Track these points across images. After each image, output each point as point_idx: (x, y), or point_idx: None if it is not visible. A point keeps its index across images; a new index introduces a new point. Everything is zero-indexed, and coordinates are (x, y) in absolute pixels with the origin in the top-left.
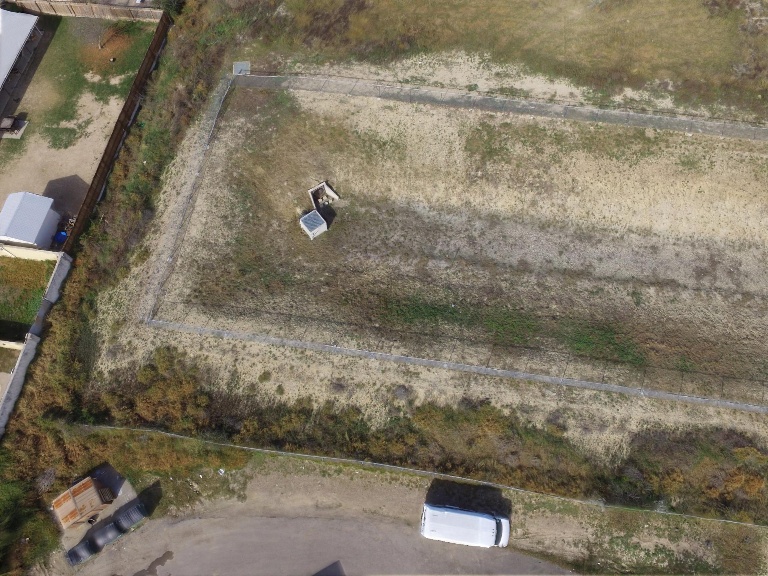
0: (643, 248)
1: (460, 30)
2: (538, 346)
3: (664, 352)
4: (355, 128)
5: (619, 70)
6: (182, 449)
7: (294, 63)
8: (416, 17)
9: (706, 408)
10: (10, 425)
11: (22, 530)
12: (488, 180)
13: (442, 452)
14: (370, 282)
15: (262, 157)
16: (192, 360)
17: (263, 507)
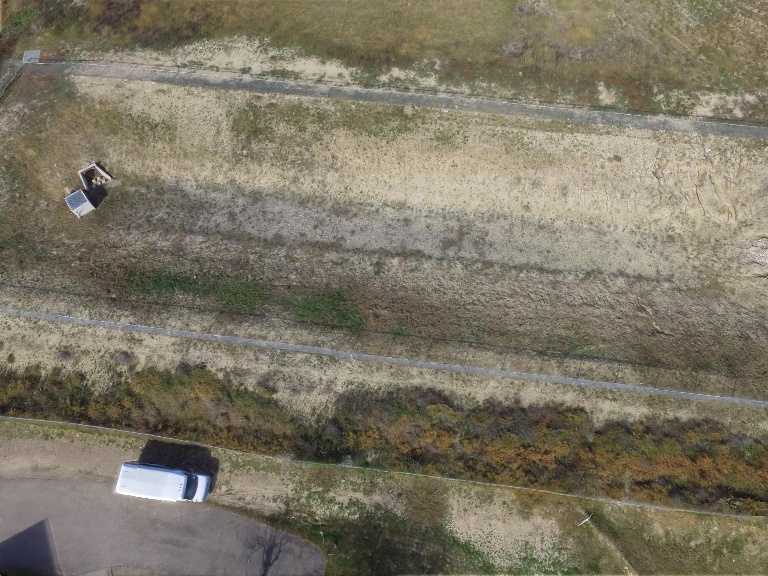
0: (396, 221)
1: (245, 16)
2: (263, 313)
3: (384, 317)
4: (129, 111)
5: (389, 51)
6: None
7: (80, 51)
8: (205, 5)
9: (410, 368)
10: None
11: None
12: (253, 158)
13: (157, 414)
14: (123, 257)
15: (35, 140)
16: None
17: None
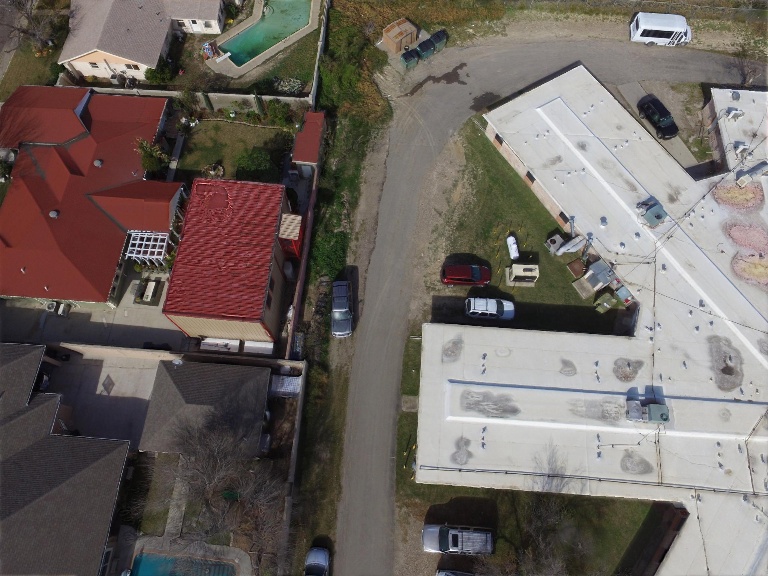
0: None
1: None
2: None
3: None
4: None
5: None
6: (460, 6)
7: None
8: None
9: None
10: (333, 1)
11: (361, 53)
12: None
13: None
14: None
15: None
16: None
17: (520, 39)
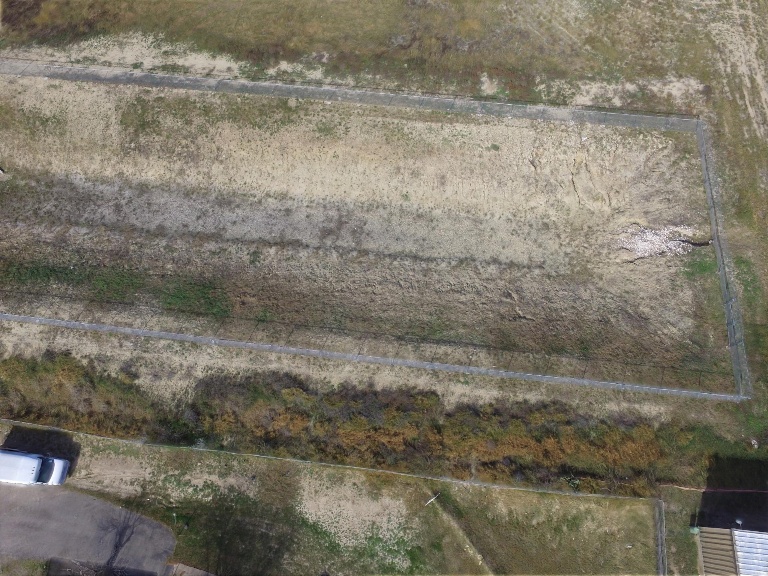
0: (277, 211)
1: (141, 12)
2: (133, 301)
3: (251, 304)
4: (21, 106)
5: (278, 45)
6: None
7: None
8: (104, 1)
9: (269, 354)
10: None
11: None
12: (140, 151)
13: (22, 401)
14: (5, 248)
15: None
16: None
17: None
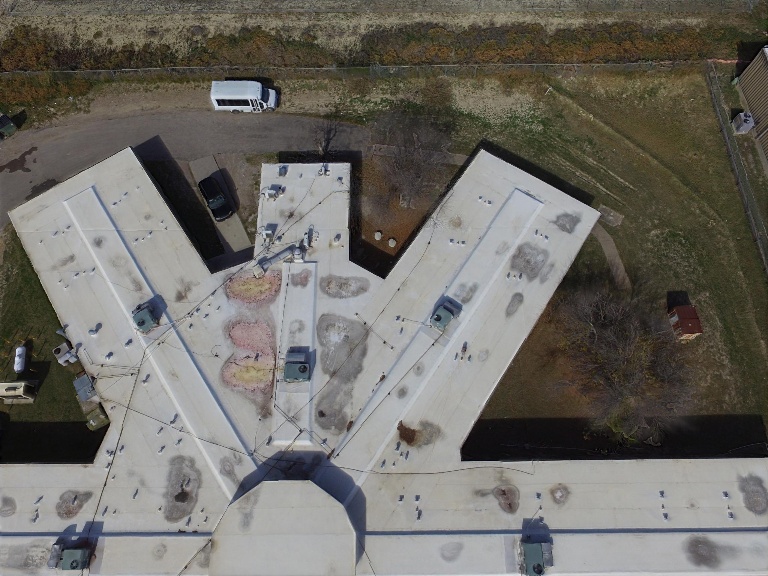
0: None
1: None
2: None
3: None
4: None
5: None
6: (39, 84)
7: None
8: None
9: (412, 13)
10: None
11: None
12: None
13: (229, 63)
14: None
15: None
16: (42, 31)
17: (103, 115)
